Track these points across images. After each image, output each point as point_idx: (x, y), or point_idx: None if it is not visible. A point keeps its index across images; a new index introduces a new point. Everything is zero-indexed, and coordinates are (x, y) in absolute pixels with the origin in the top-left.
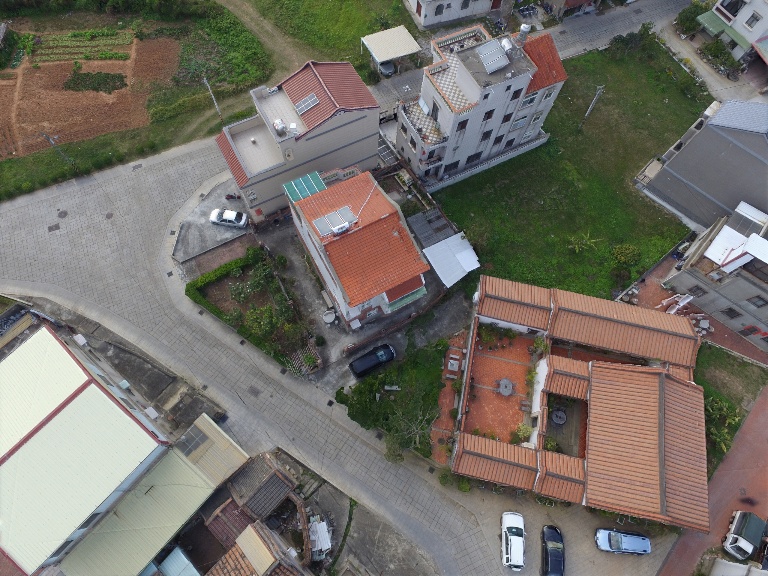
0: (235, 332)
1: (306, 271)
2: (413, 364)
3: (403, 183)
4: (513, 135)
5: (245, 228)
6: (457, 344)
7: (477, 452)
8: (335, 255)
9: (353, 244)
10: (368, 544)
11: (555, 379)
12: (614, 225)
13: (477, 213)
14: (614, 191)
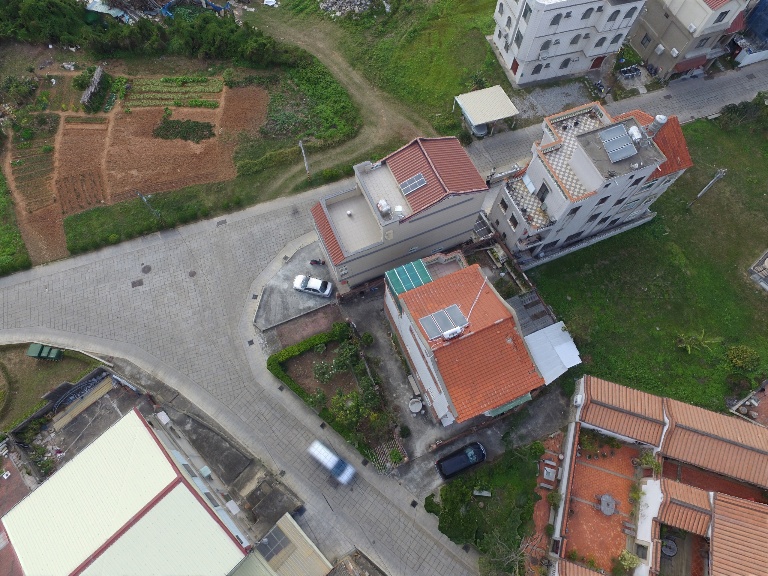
0: (316, 413)
1: (391, 351)
2: (506, 469)
3: (497, 260)
4: (619, 215)
5: (329, 297)
6: (552, 448)
7: None
8: (444, 362)
9: (463, 351)
10: None
11: (671, 509)
12: (727, 321)
13: (574, 297)
14: (727, 281)
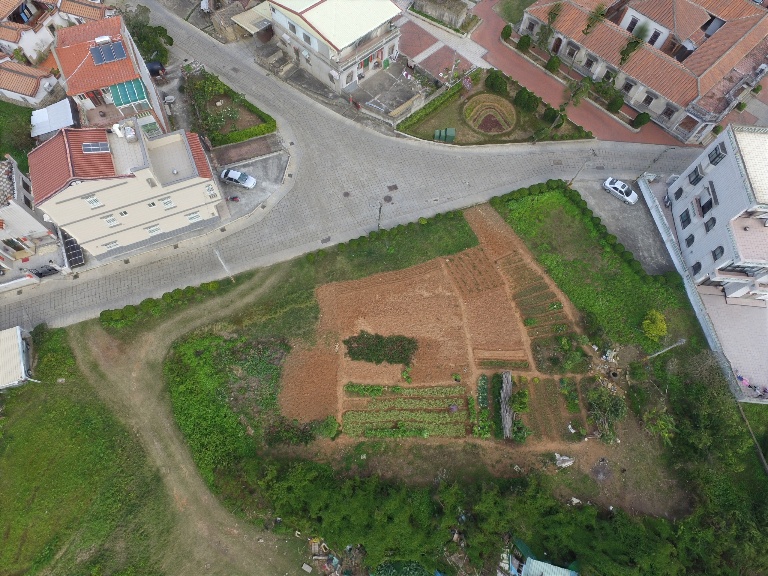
0: None
1: None
2: None
3: None
4: None
5: None
6: None
7: (94, 8)
8: (116, 32)
9: None
10: (182, 4)
11: None
12: None
13: None
14: None
